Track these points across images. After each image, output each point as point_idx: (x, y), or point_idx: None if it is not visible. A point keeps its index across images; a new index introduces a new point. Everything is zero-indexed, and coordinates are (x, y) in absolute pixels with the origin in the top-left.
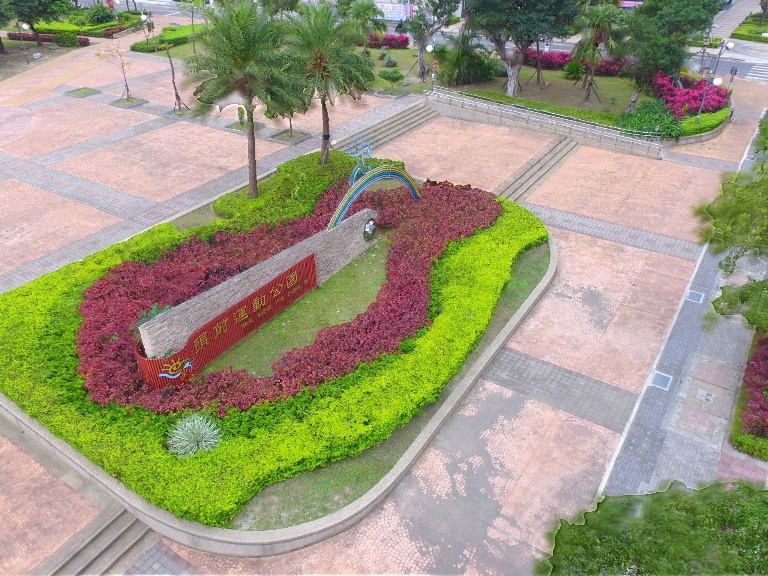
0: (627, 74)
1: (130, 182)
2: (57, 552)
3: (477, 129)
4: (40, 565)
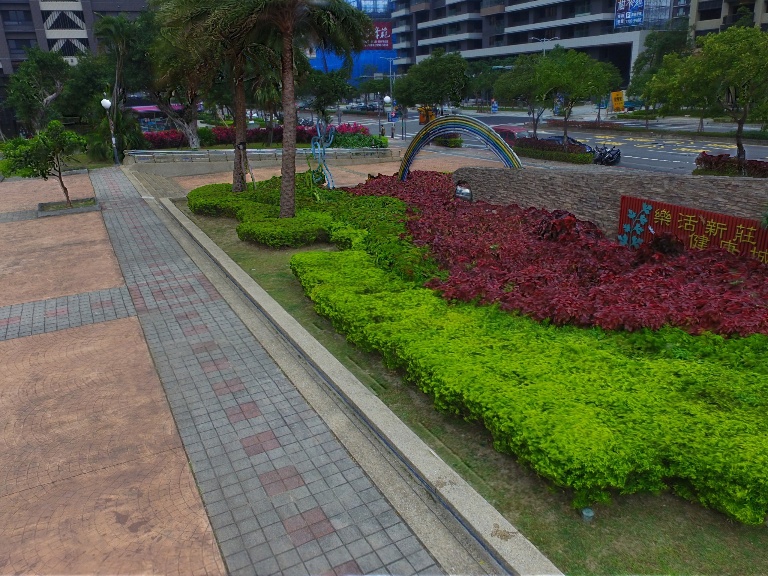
0: (315, 107)
1: None
2: None
3: None
4: None
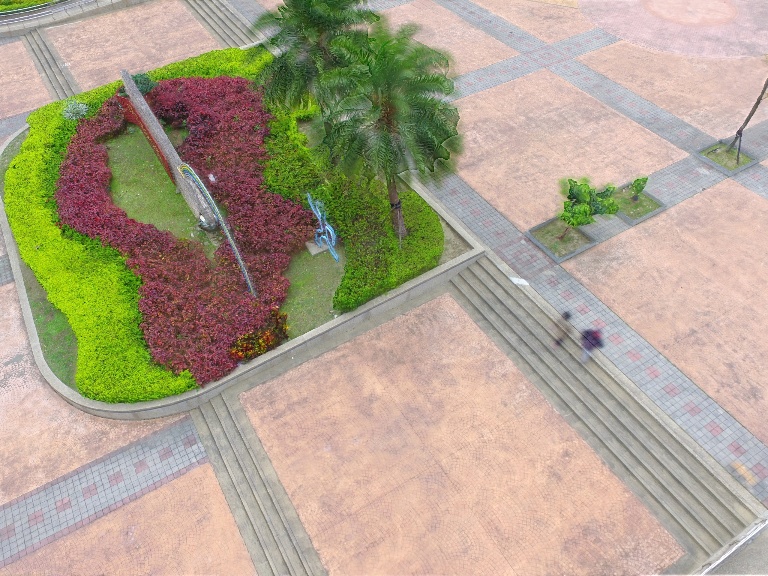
0: None
1: (465, 108)
2: (82, 91)
3: (555, 575)
4: (81, 88)
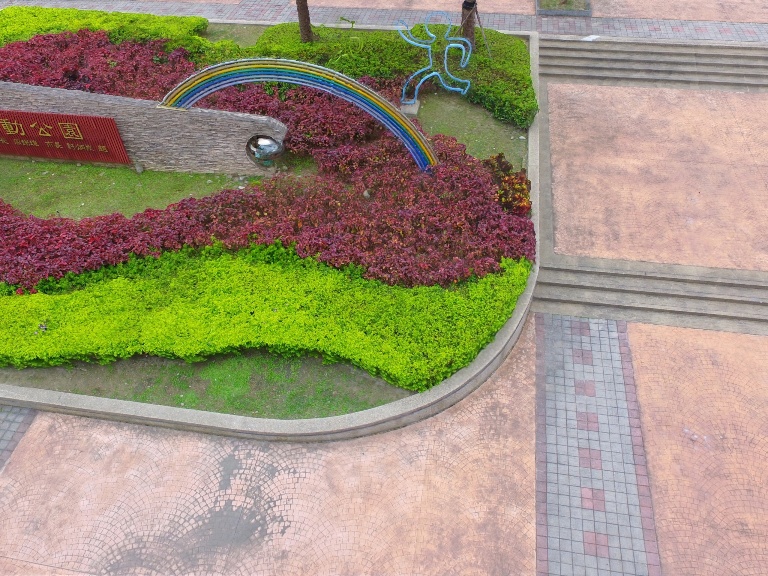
0: None
1: None
2: None
3: None
4: None
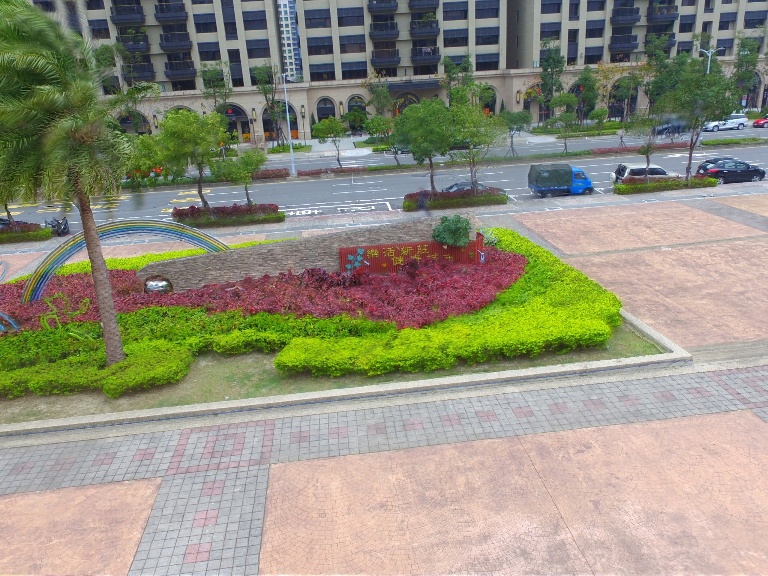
0: None
1: None
2: None
3: None
4: (587, 256)
